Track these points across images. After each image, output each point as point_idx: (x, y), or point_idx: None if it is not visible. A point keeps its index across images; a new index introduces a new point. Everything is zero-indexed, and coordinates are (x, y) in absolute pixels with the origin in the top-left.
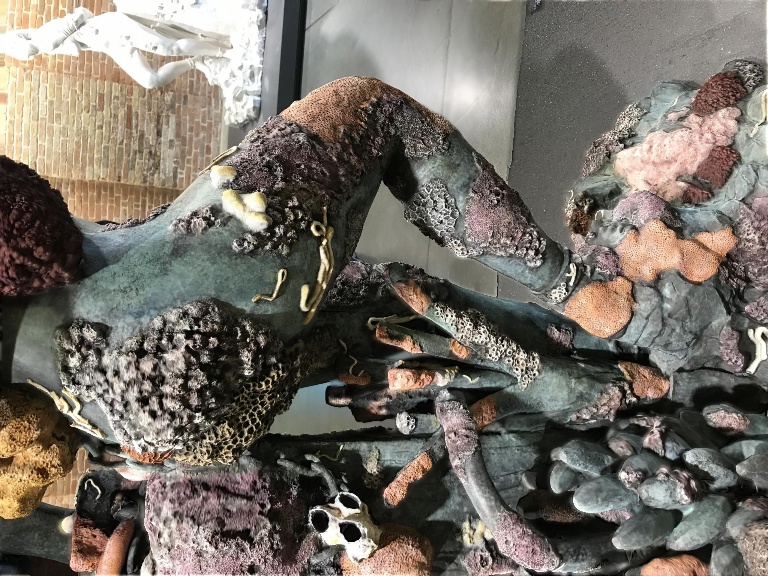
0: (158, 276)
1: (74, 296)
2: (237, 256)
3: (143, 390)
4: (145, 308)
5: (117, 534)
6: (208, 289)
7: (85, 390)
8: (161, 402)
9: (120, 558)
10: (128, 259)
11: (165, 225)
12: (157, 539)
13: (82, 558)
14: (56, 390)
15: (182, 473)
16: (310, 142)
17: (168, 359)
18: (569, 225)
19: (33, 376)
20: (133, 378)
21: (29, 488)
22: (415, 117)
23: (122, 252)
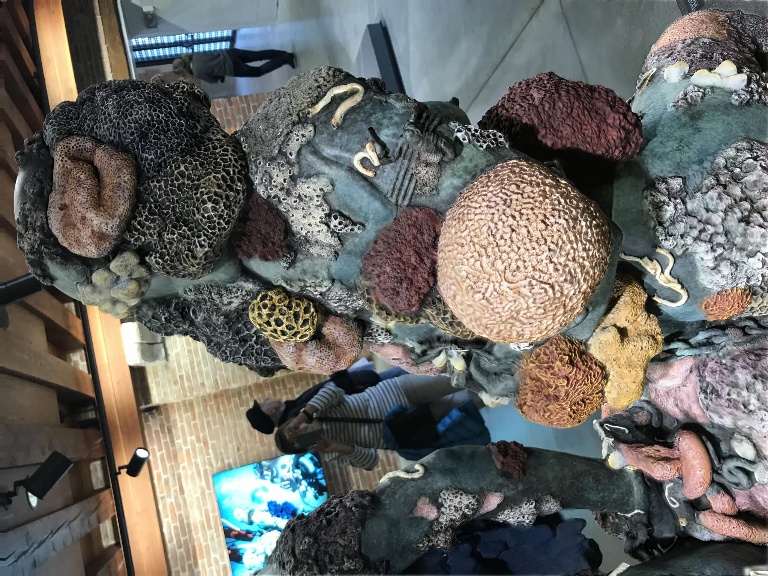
0: (695, 134)
1: (644, 164)
2: (740, 107)
3: (742, 210)
4: (702, 156)
5: (686, 434)
6: (737, 132)
7: (680, 239)
8: (761, 216)
9: (705, 451)
10: (662, 132)
11: (663, 111)
12: (743, 411)
13: (667, 463)
14: (648, 255)
15: (734, 347)
16: (713, 41)
17: (749, 181)
18: None
19: (626, 248)
20: (728, 205)
21: (648, 357)
22: (759, 19)
23: (652, 131)
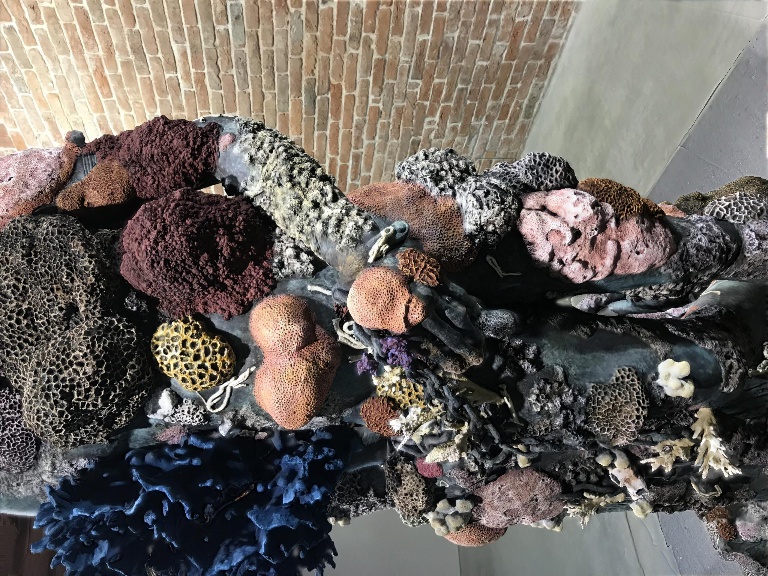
0: None
1: None
2: None
3: None
4: None
5: None
6: None
7: None
8: None
9: None
10: None
11: None
12: None
13: None
14: None
15: None
16: None
17: None
18: (715, 521)
19: None
20: None
21: None
22: None
23: None
